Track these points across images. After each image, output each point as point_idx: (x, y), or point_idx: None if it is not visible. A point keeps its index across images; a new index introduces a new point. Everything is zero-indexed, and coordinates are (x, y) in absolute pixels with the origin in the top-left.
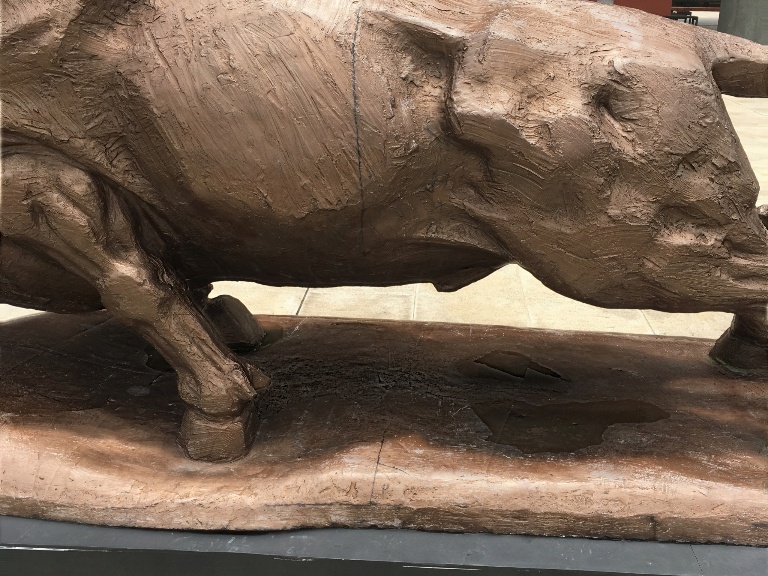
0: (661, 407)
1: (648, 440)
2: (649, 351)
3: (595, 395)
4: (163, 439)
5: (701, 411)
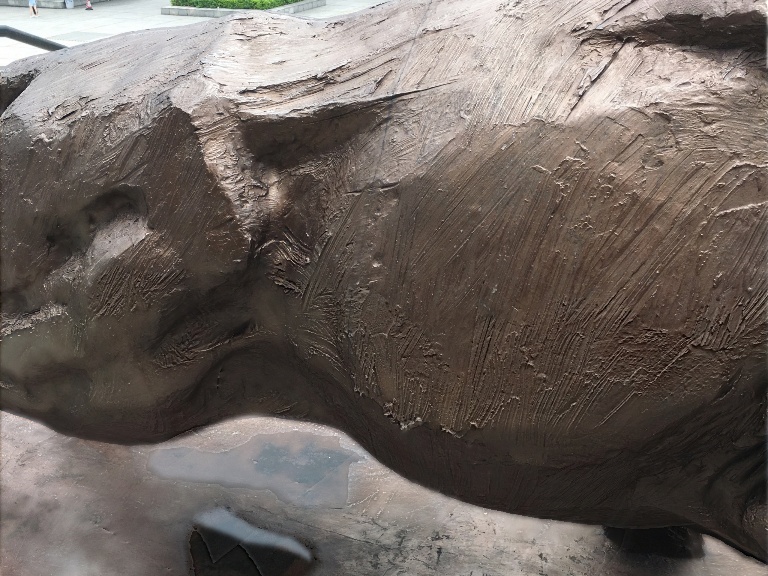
0: (145, 462)
1: (211, 430)
2: (10, 565)
3: (191, 491)
4: (722, 549)
5: (116, 447)
